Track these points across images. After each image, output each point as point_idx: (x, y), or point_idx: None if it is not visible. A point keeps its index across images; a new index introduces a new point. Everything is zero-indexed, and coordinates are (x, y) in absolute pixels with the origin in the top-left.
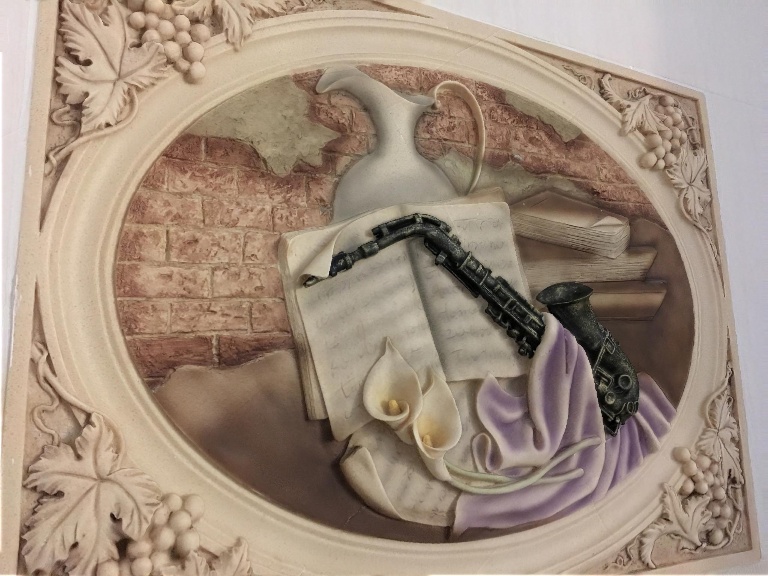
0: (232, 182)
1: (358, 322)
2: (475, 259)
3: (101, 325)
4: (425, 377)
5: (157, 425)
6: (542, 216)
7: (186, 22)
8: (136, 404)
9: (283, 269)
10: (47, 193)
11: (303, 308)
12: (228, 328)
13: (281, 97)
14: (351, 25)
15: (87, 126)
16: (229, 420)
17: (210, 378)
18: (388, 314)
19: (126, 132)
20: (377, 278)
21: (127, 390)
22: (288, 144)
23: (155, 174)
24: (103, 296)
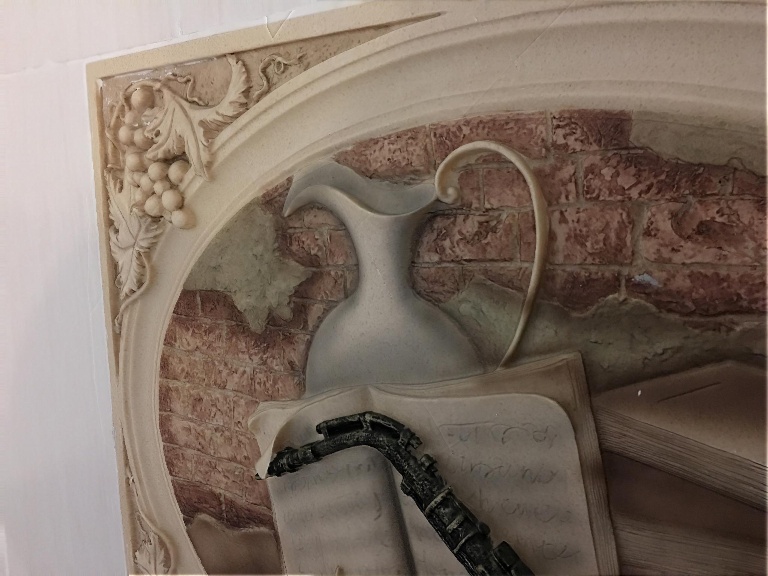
0: (220, 339)
1: (316, 533)
2: (456, 504)
3: (160, 461)
4: None
5: (196, 554)
6: (680, 428)
7: (153, 173)
8: (184, 531)
9: None
10: None
11: (273, 494)
12: (229, 490)
13: (251, 230)
14: (316, 93)
15: (121, 295)
16: (232, 575)
17: (217, 533)
18: (342, 538)
19: (155, 289)
20: (332, 487)
21: (178, 518)
22: (260, 292)
23: (169, 332)
24: None
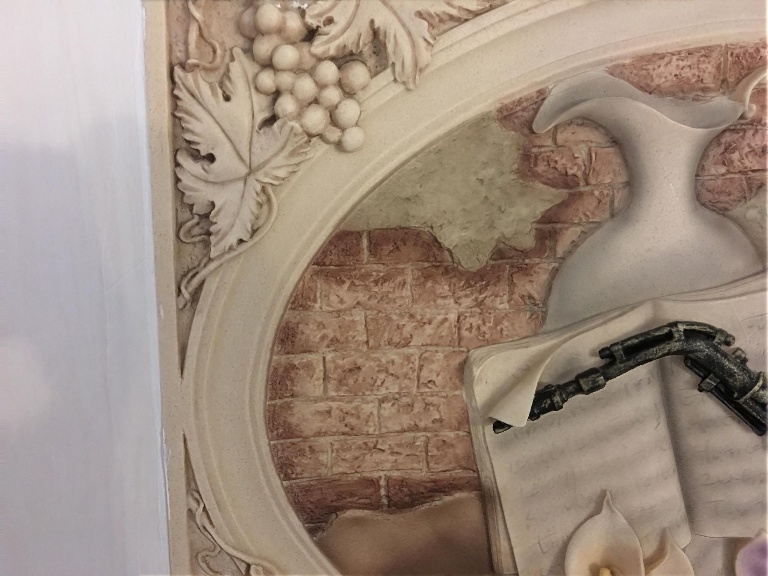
0: (404, 287)
1: (567, 468)
2: None
3: (256, 468)
4: (657, 542)
5: (321, 567)
6: None
7: (330, 74)
8: (298, 547)
9: (469, 398)
10: (185, 328)
11: (493, 448)
12: (399, 468)
13: (477, 150)
14: None
15: (216, 249)
16: (399, 567)
17: (377, 525)
18: (612, 460)
19: (268, 237)
20: (601, 413)
21: (288, 533)
22: (484, 222)
23: (304, 291)
24: (256, 438)
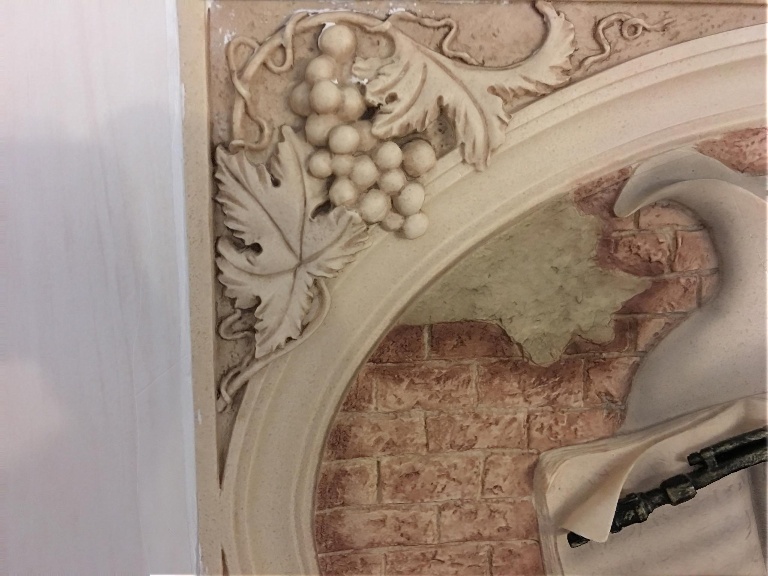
0: (468, 385)
1: None
2: None
3: None
4: None
5: None
6: None
7: (394, 158)
8: None
9: (539, 505)
10: (225, 433)
11: (566, 560)
12: None
13: (552, 236)
14: (694, 70)
15: (262, 349)
16: None
17: None
18: (699, 574)
19: (318, 331)
20: (688, 522)
21: None
22: (559, 314)
23: (358, 391)
24: (302, 550)
